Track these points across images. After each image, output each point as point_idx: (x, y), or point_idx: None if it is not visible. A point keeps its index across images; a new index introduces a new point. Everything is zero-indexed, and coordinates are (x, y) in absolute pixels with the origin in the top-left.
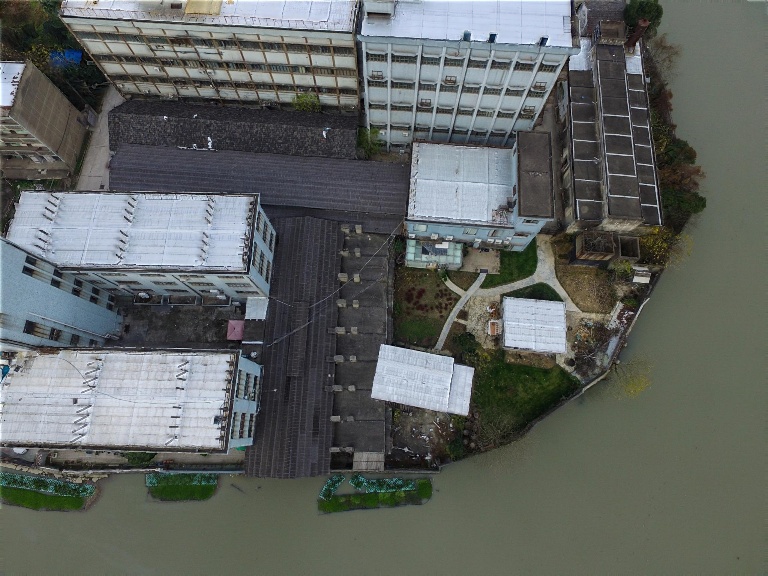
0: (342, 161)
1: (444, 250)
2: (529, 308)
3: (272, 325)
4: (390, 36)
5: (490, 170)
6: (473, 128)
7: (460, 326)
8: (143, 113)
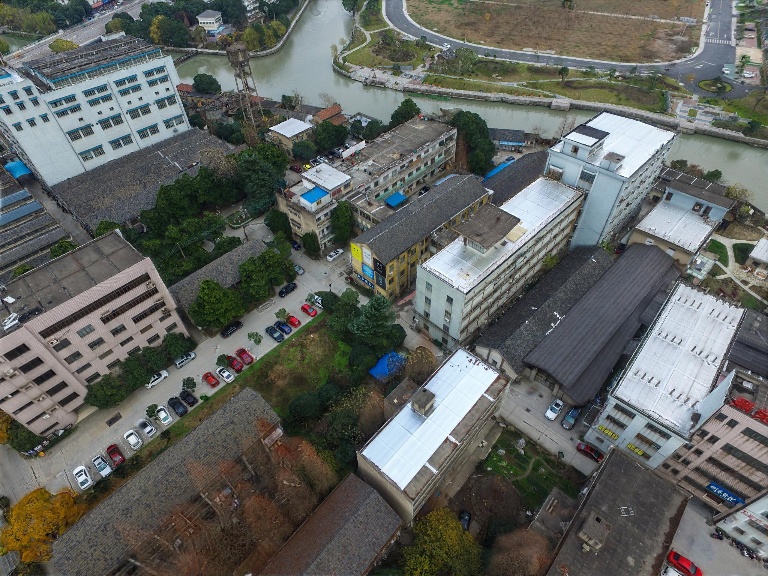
0: (616, 265)
1: (702, 262)
2: (761, 251)
3: (738, 358)
4: (637, 171)
5: (673, 212)
6: (634, 207)
7: (754, 287)
8: (512, 332)
